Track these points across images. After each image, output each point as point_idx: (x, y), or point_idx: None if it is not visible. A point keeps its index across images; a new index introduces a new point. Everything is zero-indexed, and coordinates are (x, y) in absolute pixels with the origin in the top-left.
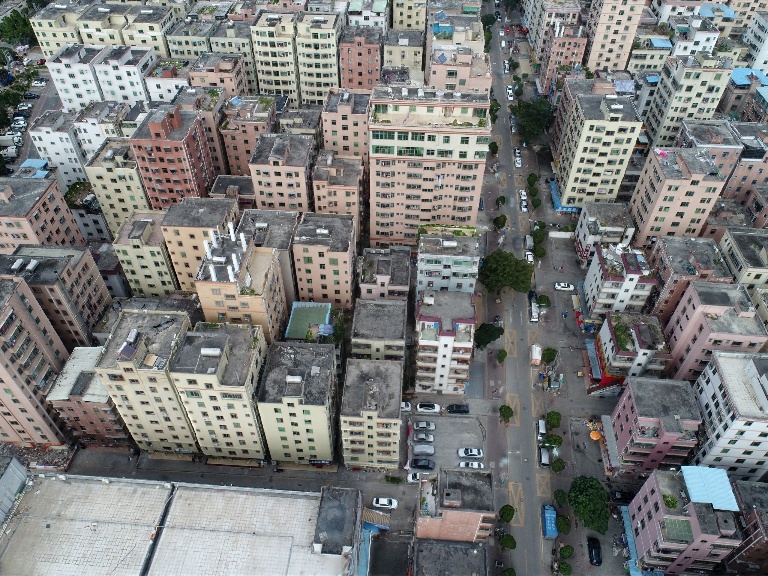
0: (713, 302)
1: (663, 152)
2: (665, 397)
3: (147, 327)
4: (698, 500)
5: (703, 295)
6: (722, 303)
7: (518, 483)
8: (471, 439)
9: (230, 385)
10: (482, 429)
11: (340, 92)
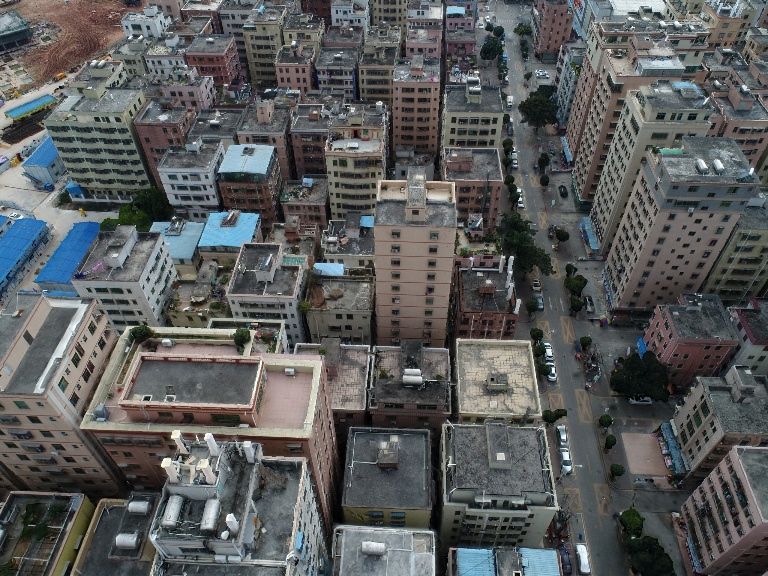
0: (435, 26)
1: (432, 78)
2: (459, 38)
3: (737, 7)
4: (462, 7)
5: (439, 28)
6: (430, 26)
7: (518, 70)
8: (543, 81)
9: (676, 3)
10: (538, 84)
11: (765, 123)
